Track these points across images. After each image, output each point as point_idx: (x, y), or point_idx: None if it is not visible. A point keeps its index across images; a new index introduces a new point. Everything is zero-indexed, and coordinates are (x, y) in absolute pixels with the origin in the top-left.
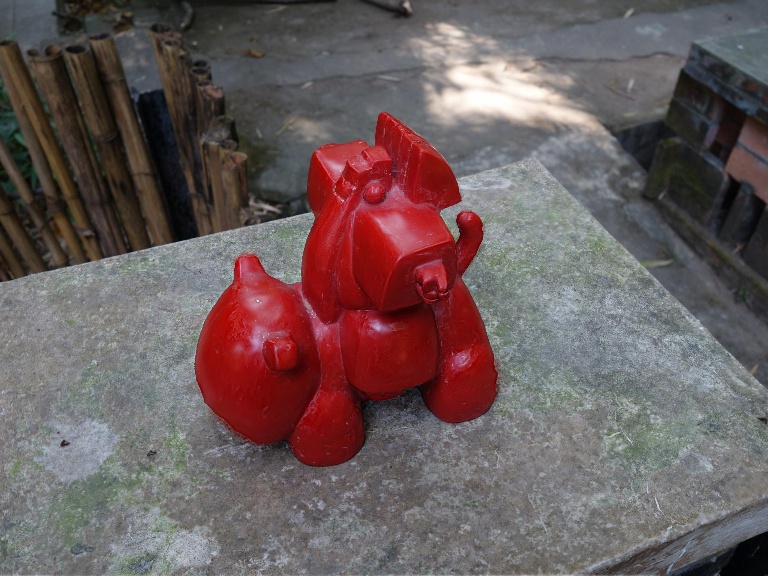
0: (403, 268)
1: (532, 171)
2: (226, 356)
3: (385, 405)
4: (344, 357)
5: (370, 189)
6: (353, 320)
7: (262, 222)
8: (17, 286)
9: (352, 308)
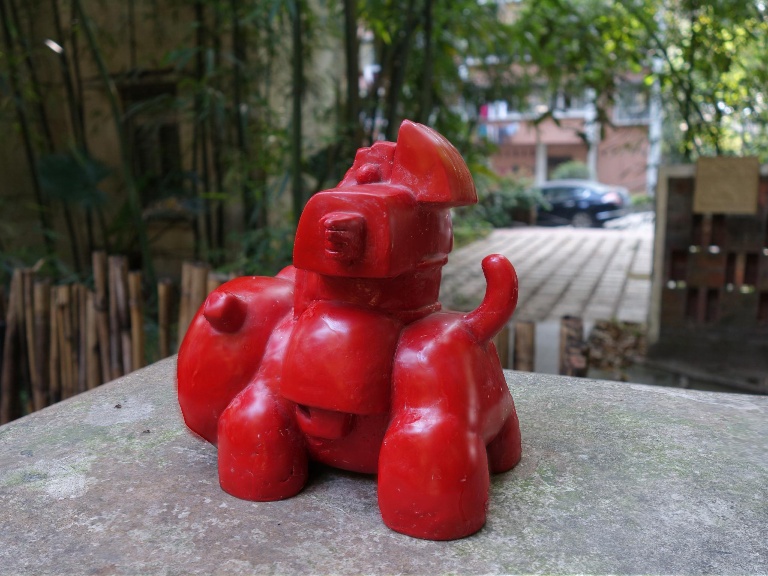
0: (316, 209)
1: None
2: None
3: (350, 487)
4: None
5: None
6: None
7: None
8: None
9: (312, 298)
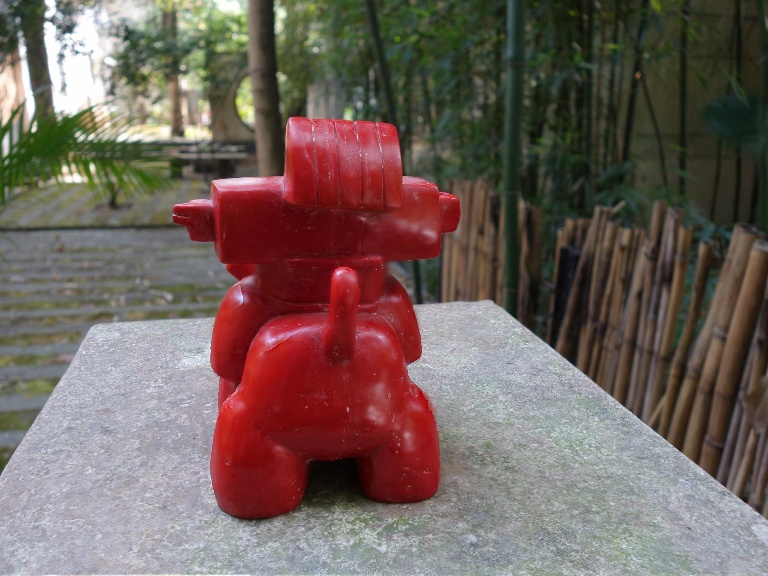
0: None
1: None
2: None
3: None
4: None
5: None
6: None
7: None
8: (487, 305)
9: None
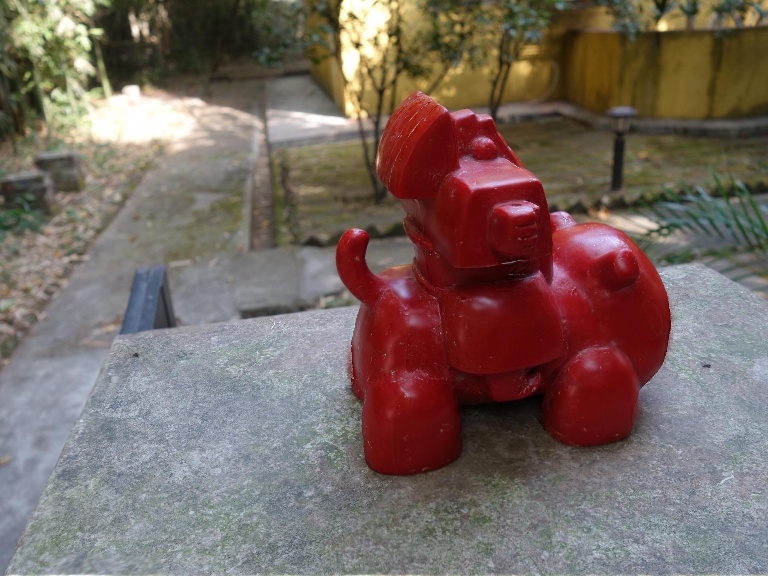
0: None
1: None
2: None
3: None
4: None
5: None
6: None
7: None
8: None
9: None
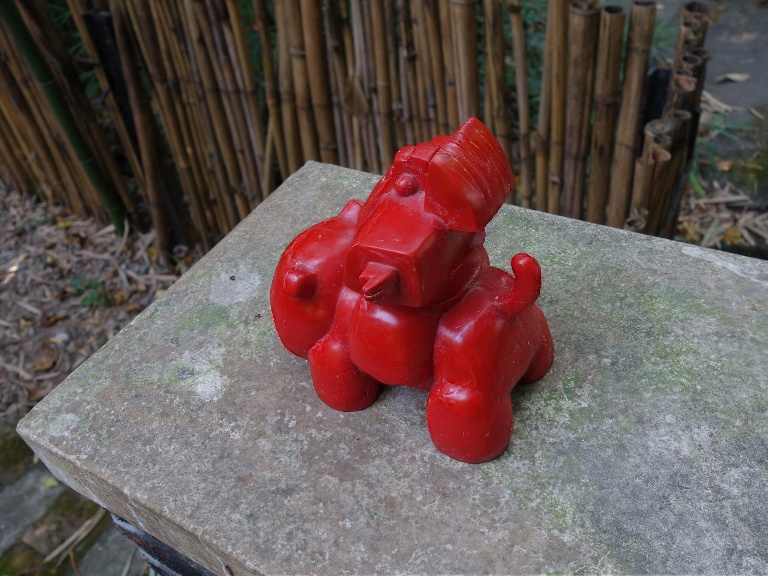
0: (357, 256)
1: None
2: None
3: (411, 396)
4: None
5: (398, 179)
6: None
7: None
8: (316, 167)
9: None
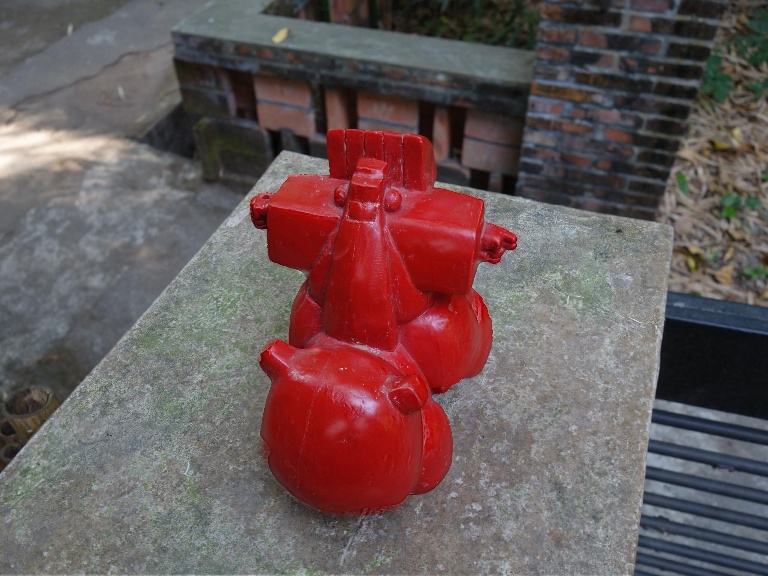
0: (477, 242)
1: (295, 162)
2: (360, 437)
3: None
4: (424, 367)
5: (392, 197)
6: (420, 328)
7: (111, 348)
8: None
9: (413, 319)
